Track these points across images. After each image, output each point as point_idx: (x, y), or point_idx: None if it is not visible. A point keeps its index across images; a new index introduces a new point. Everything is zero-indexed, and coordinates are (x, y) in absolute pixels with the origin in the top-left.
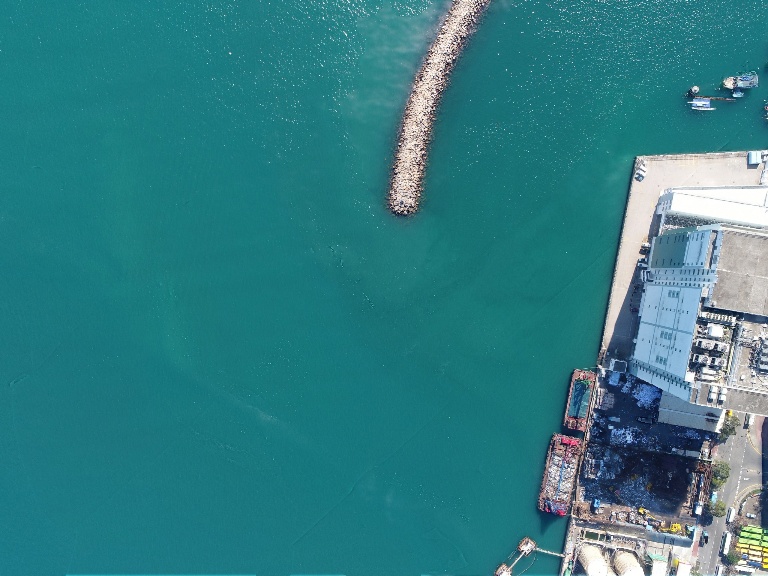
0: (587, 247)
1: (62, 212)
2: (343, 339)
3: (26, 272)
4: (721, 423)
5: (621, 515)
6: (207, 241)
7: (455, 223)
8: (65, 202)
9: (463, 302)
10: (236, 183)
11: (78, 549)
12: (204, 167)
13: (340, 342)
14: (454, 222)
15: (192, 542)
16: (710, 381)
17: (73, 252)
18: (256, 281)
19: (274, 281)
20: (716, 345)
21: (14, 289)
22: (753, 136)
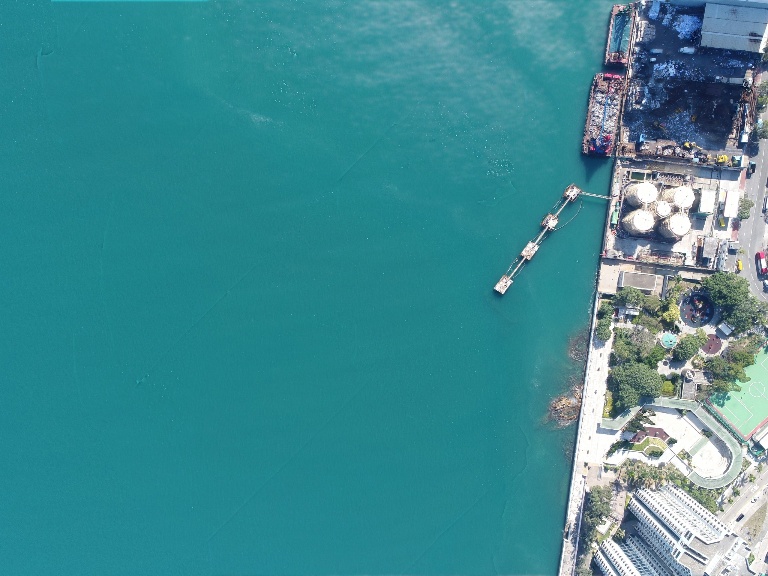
0: None
1: None
2: None
3: None
4: (764, 42)
5: (667, 151)
6: None
7: None
8: None
9: None
10: None
11: (115, 210)
12: None
13: None
14: None
15: (233, 191)
16: None
17: None
18: None
19: None
20: None
21: None
22: None
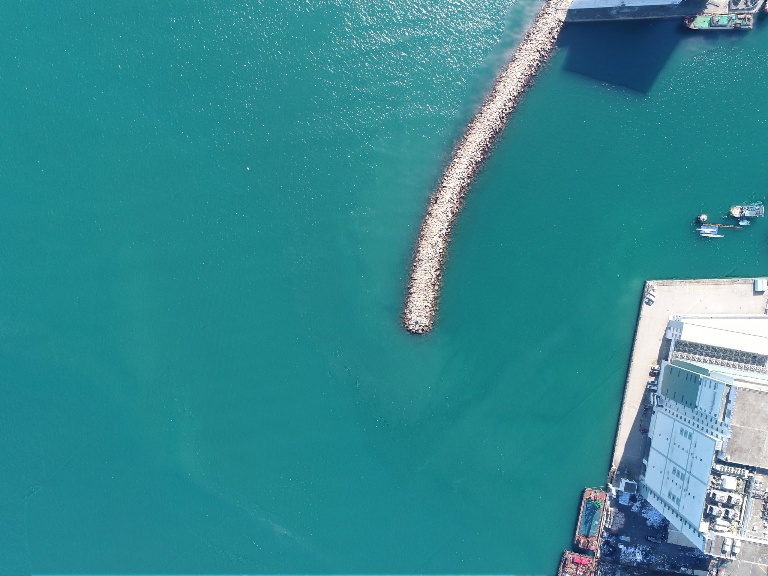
0: (598, 367)
1: (77, 325)
2: (359, 463)
3: (39, 384)
4: None
5: None
6: (225, 365)
7: (469, 342)
8: (80, 315)
9: (476, 420)
10: (254, 308)
11: None
12: (223, 292)
13: (356, 466)
14: (468, 341)
15: None
16: (723, 530)
17: (87, 364)
18: (273, 405)
19: (291, 405)
20: (730, 497)
21: (27, 401)
22: (759, 263)
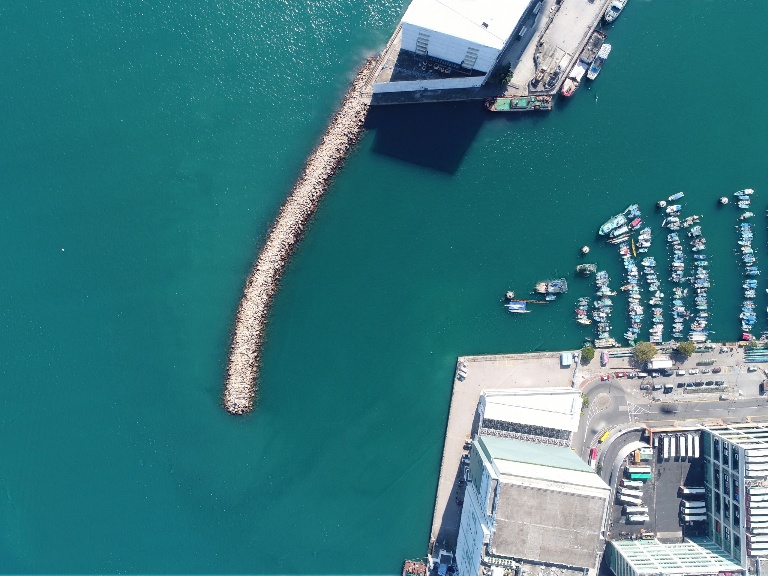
0: (416, 442)
1: None
2: (173, 550)
3: None
4: None
5: None
6: (34, 458)
7: (289, 420)
8: None
9: (299, 497)
10: (62, 401)
11: None
12: (29, 386)
13: (170, 553)
14: (288, 419)
15: None
16: None
17: None
18: (85, 496)
19: (103, 496)
20: None
21: None
22: (566, 337)
